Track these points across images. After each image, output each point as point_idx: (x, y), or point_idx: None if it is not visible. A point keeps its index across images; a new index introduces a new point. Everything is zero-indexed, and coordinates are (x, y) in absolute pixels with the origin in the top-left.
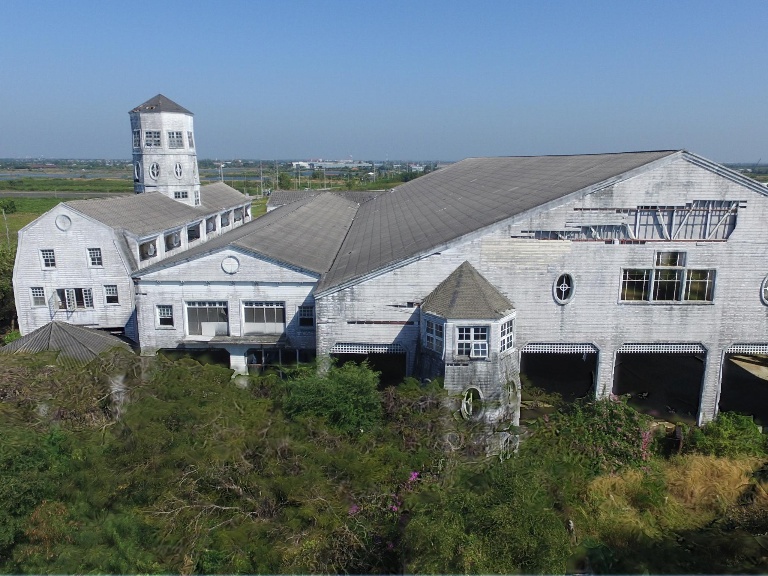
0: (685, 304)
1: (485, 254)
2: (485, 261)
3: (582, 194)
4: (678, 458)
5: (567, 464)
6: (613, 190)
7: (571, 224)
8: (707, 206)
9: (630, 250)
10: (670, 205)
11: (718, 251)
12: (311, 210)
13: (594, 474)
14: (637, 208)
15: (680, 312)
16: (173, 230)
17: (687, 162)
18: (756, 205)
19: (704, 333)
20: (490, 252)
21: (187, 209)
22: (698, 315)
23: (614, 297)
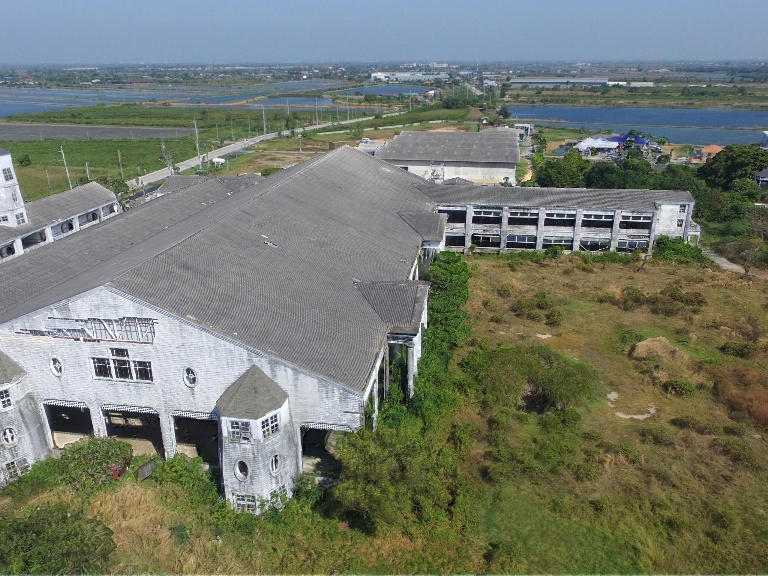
0: (136, 382)
1: (4, 342)
2: (5, 346)
3: (50, 309)
4: (139, 482)
5: (43, 482)
6: (69, 307)
7: (49, 327)
8: (135, 320)
9: (92, 346)
10: (109, 319)
11: (149, 350)
12: (123, 223)
13: (47, 492)
14: (88, 319)
15: (135, 387)
16: None
17: (111, 292)
18: (164, 322)
19: (154, 402)
20: (6, 341)
21: (2, 232)
22: (147, 390)
23: (90, 374)
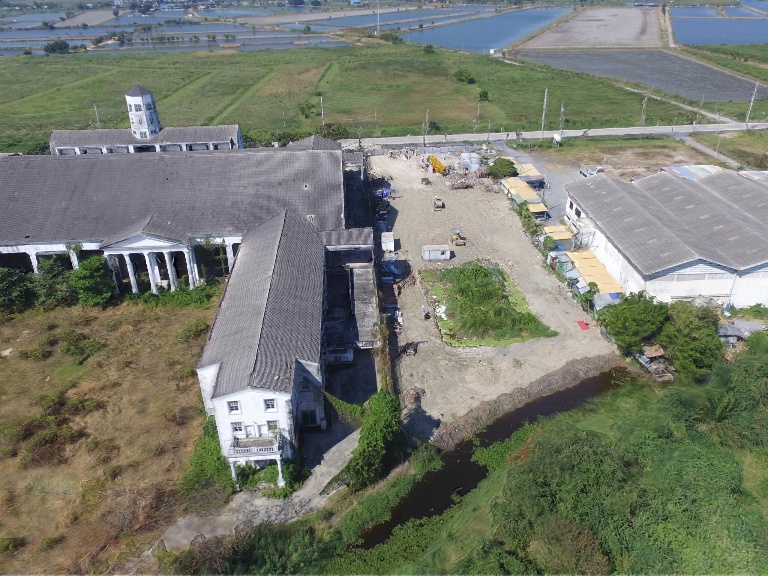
0: None
1: None
2: None
3: None
4: None
5: None
6: None
7: None
8: None
9: None
10: None
11: None
12: None
13: None
14: None
15: None
16: (90, 147)
17: None
18: None
19: None
20: None
21: (128, 139)
22: None
23: None
